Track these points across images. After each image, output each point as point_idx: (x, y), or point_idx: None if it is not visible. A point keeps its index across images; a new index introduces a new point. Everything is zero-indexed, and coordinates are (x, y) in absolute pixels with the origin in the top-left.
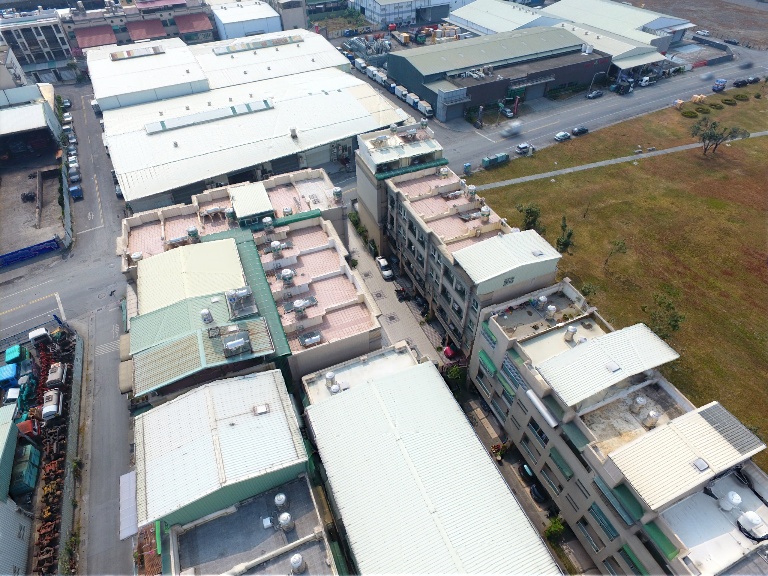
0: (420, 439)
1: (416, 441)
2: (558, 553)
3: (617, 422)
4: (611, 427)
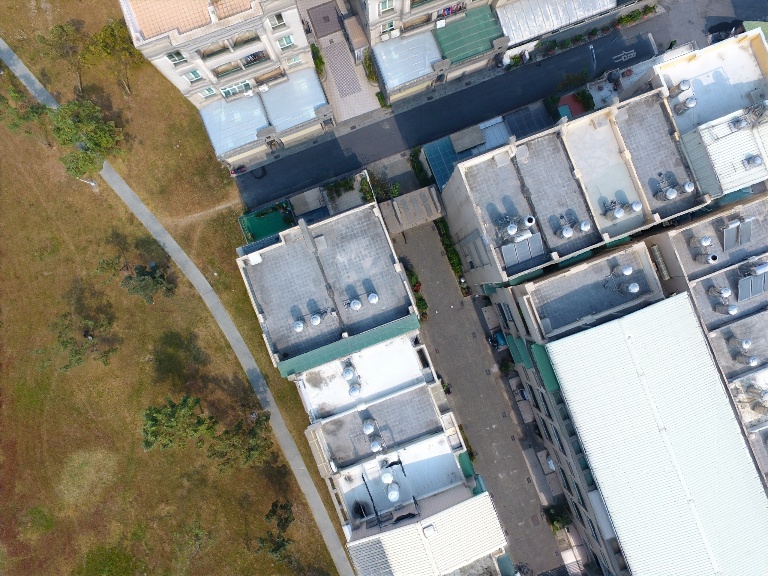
0: (694, 572)
1: (699, 570)
2: (467, 442)
3: (455, 575)
4: (464, 570)
